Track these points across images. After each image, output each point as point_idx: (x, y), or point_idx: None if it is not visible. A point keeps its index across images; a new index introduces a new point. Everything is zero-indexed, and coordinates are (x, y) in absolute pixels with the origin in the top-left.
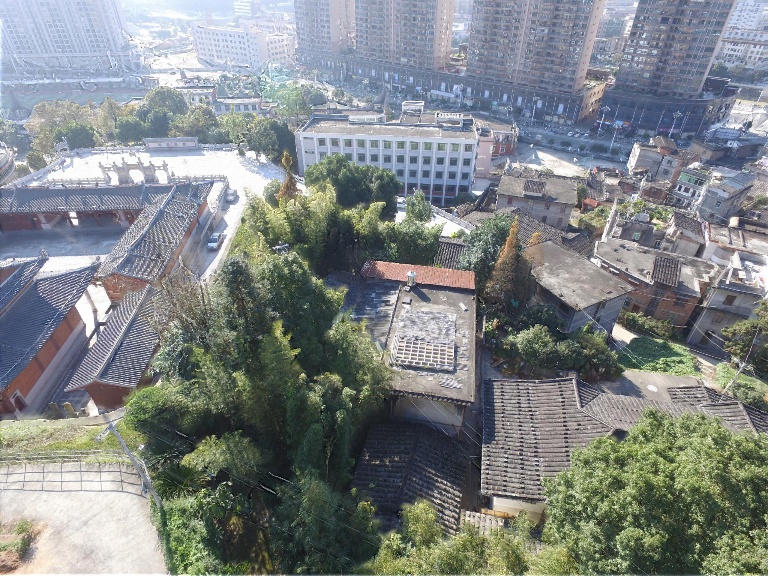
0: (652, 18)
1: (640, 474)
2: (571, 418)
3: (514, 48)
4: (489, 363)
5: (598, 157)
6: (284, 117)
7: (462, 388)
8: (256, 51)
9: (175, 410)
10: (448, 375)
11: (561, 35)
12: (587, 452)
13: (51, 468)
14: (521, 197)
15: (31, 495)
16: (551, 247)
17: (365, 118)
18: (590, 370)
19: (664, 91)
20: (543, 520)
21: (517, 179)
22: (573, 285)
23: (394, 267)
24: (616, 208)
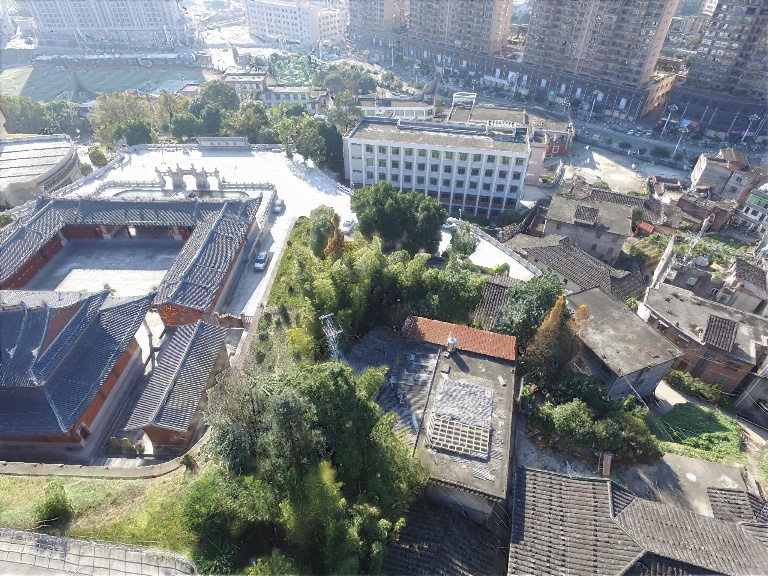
0: (736, 7)
1: None
2: (602, 527)
3: (577, 35)
4: (523, 432)
5: (659, 162)
6: (333, 118)
7: (494, 481)
8: (308, 27)
9: (225, 514)
10: (481, 464)
11: (631, 24)
12: None
13: (116, 555)
14: (571, 224)
15: None
16: (598, 296)
17: (414, 110)
18: (627, 451)
19: (741, 89)
20: None
21: (568, 201)
22: (618, 345)
23: (435, 326)
24: (673, 249)
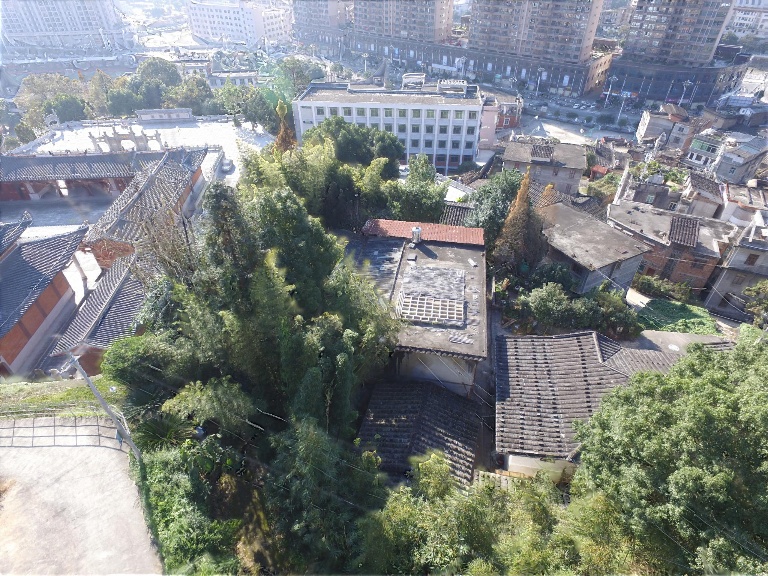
0: None
1: (698, 404)
2: (592, 372)
3: (518, 17)
4: (499, 324)
5: (605, 128)
6: (281, 87)
7: (473, 343)
8: (252, 27)
9: (158, 359)
10: (458, 330)
11: (567, 2)
12: (627, 387)
13: (22, 423)
14: (528, 163)
15: None
16: (562, 209)
17: None
18: (607, 329)
19: (673, 60)
20: (564, 479)
21: (524, 145)
22: (586, 246)
23: (398, 225)
24: (629, 170)
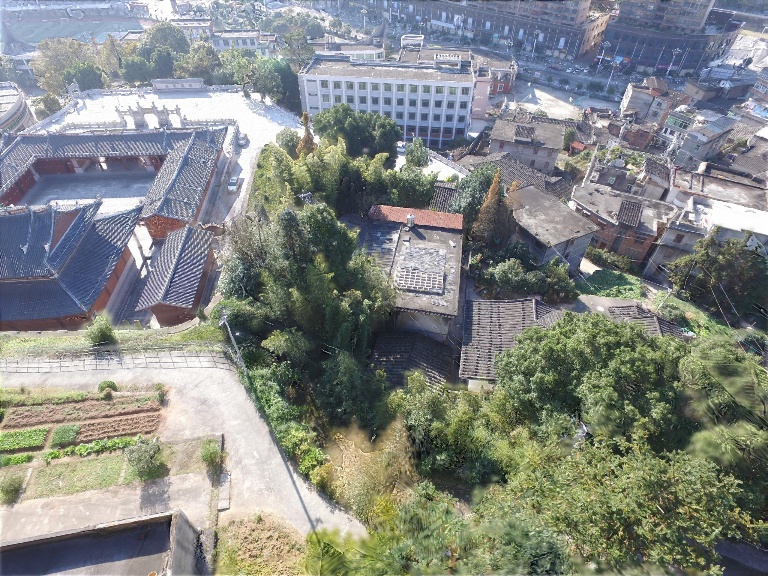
0: None
1: (546, 343)
2: None
3: None
4: (472, 289)
5: (594, 96)
6: (286, 57)
7: (448, 306)
8: None
9: (245, 316)
10: (438, 296)
11: None
12: (521, 335)
13: (163, 355)
14: (512, 142)
15: (154, 371)
16: (533, 191)
17: (364, 53)
18: (552, 295)
19: (667, 25)
20: None
21: (510, 124)
22: (548, 225)
23: (396, 210)
24: (596, 154)
